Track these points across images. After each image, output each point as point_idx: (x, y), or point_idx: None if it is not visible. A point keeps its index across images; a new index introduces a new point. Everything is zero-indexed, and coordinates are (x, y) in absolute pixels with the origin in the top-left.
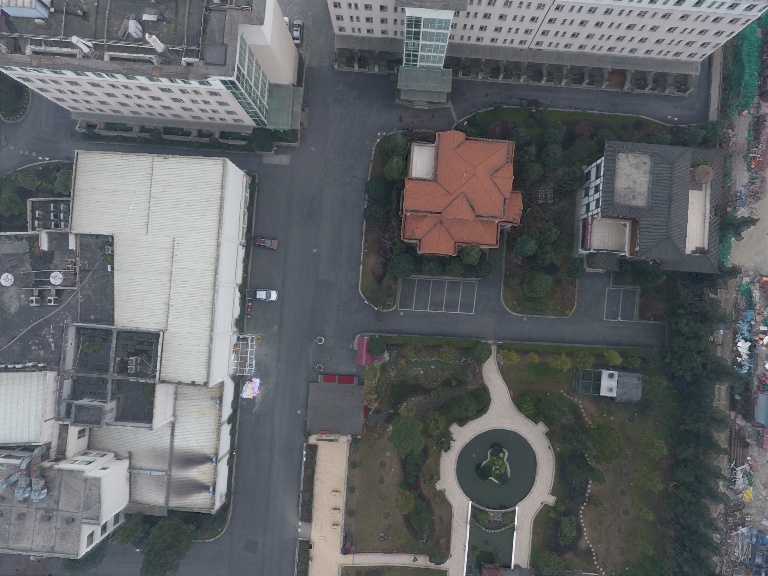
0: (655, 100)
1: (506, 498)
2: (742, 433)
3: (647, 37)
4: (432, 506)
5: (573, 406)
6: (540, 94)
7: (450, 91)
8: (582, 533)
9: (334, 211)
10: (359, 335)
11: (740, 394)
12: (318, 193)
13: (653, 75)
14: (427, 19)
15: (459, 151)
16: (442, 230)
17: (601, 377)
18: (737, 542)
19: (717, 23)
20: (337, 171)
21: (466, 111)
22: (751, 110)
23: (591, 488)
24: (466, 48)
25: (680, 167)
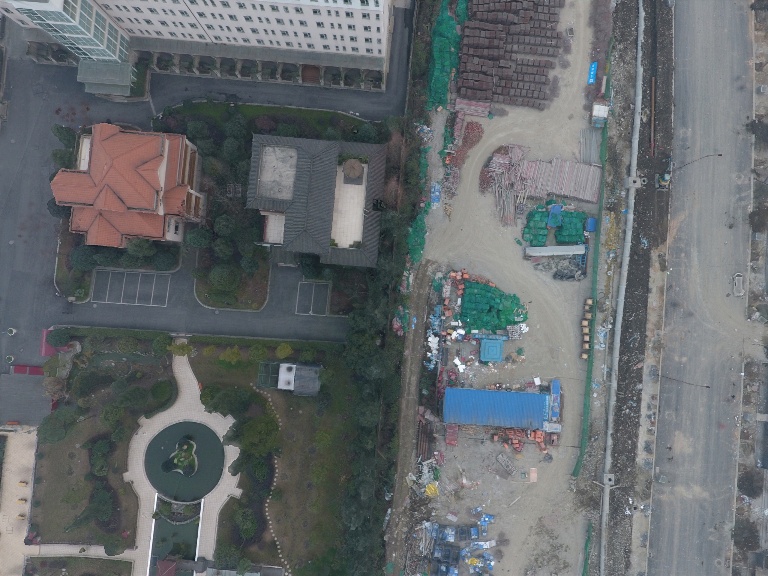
0: (353, 96)
1: (194, 490)
2: (429, 428)
3: (307, 32)
4: (119, 498)
5: (259, 399)
6: (239, 89)
7: (129, 84)
8: (267, 526)
9: (32, 203)
10: (52, 327)
11: (427, 389)
12: (16, 185)
13: (342, 71)
14: (39, 11)
15: (105, 143)
16: (102, 222)
17: (279, 370)
18: (421, 536)
19: (353, 18)
20: (36, 164)
21: (165, 105)
22: (448, 106)
23: (277, 481)
24: (155, 42)
25: (321, 161)
